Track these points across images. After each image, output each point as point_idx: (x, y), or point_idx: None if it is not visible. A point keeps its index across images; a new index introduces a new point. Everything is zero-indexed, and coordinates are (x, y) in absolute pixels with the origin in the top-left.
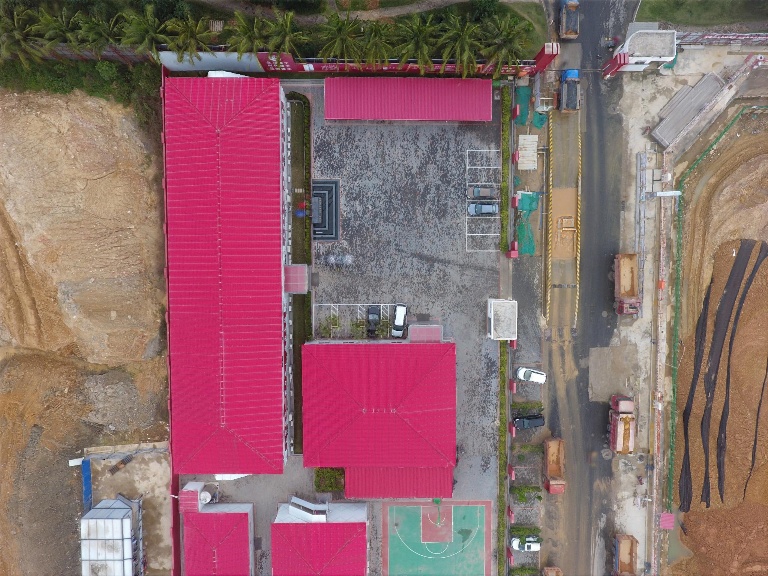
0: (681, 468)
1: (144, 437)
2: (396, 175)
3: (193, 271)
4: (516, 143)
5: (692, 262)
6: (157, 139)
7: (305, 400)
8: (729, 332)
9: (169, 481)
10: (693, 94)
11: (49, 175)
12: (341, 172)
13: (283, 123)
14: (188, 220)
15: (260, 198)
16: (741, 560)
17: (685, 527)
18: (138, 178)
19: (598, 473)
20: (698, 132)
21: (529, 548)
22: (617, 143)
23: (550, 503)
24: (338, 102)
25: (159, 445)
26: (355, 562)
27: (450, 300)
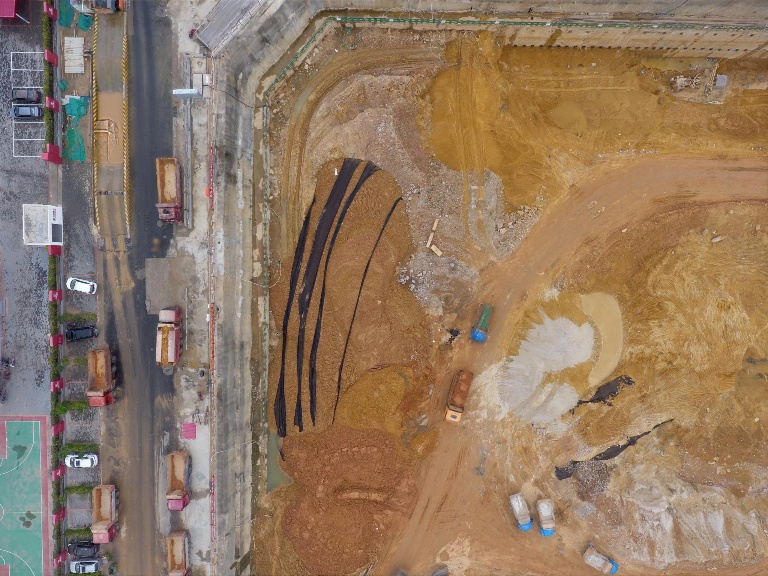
0: (276, 391)
1: None
2: None
3: None
4: (62, 46)
5: (289, 180)
6: None
7: None
8: (326, 252)
9: None
10: None
11: None
12: None
13: None
14: None
15: None
16: (329, 485)
17: (283, 452)
18: None
19: (159, 389)
20: (251, 37)
21: (78, 464)
22: (166, 47)
23: (110, 420)
24: None
25: None
26: None
27: None
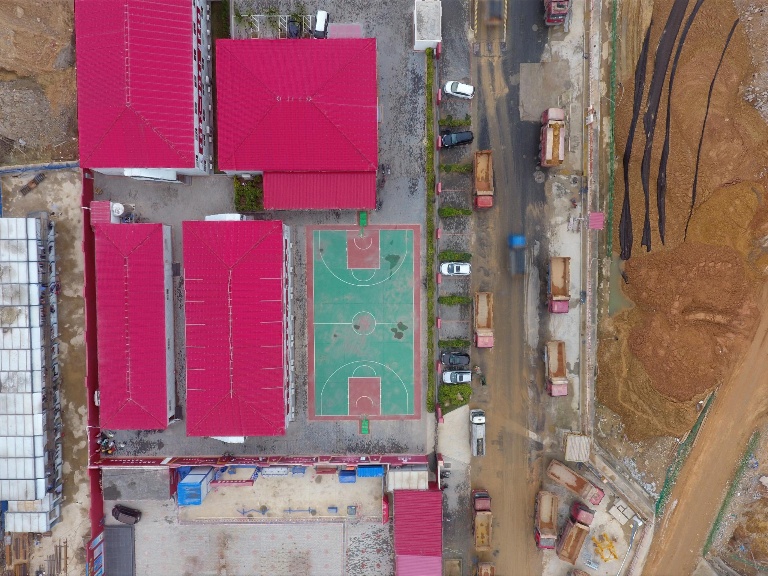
0: (621, 212)
1: (57, 155)
2: None
3: None
4: None
5: None
6: None
7: (219, 98)
8: (669, 71)
9: None
10: None
11: None
12: None
13: None
14: None
15: None
16: (683, 302)
17: (626, 275)
18: None
19: (530, 197)
20: None
21: (458, 270)
22: None
23: (481, 229)
24: None
25: (72, 164)
26: (270, 261)
27: (375, 12)
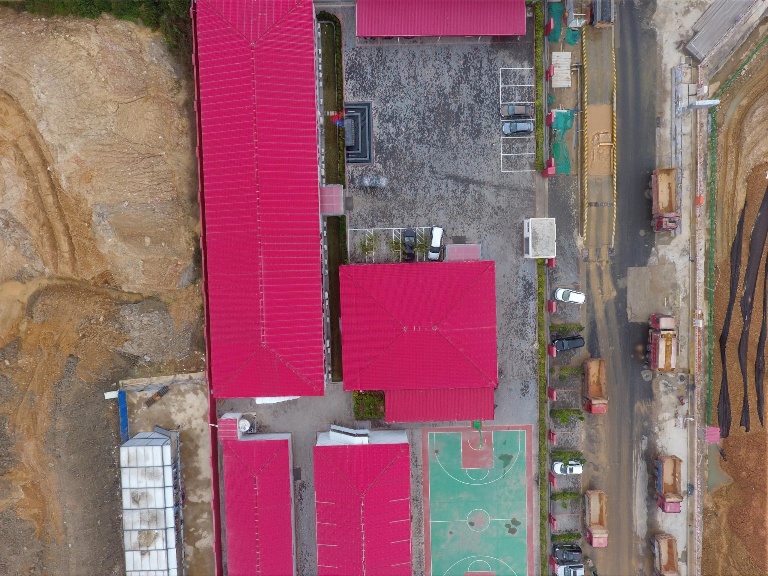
0: (719, 393)
1: (180, 368)
2: (429, 96)
3: (229, 189)
4: (549, 61)
5: (726, 185)
6: (187, 62)
7: (344, 322)
8: (764, 254)
9: (206, 412)
10: (727, 6)
11: (81, 97)
12: (373, 94)
13: (315, 41)
14: (223, 137)
15: (296, 114)
16: None
17: (724, 453)
18: (168, 103)
19: (638, 395)
20: (732, 46)
21: (571, 471)
22: (651, 58)
23: (591, 426)
24: (370, 19)
25: (195, 376)
26: (399, 483)
27: (486, 222)
